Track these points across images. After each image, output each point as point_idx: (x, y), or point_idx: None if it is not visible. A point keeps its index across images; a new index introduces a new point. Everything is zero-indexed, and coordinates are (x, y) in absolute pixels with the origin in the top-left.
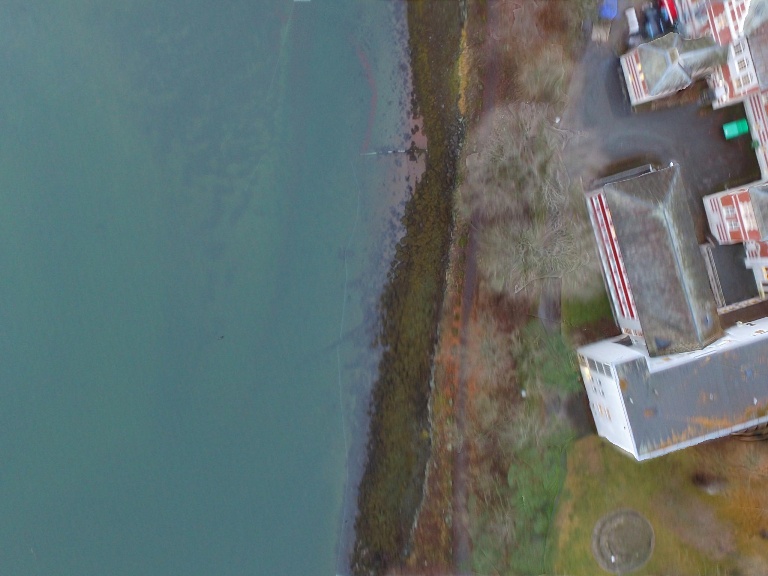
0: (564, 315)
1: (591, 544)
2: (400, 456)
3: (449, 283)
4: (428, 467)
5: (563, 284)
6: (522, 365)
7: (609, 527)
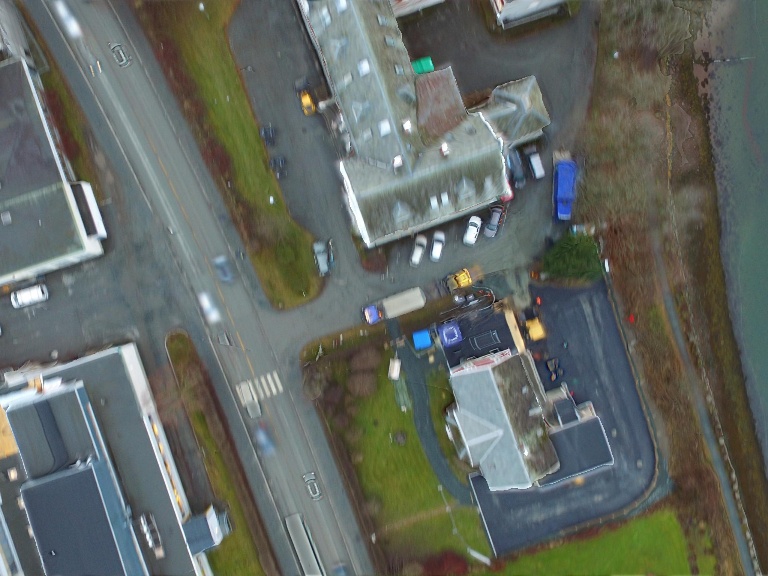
0: None
1: None
2: None
3: None
4: None
5: None
6: None
7: None
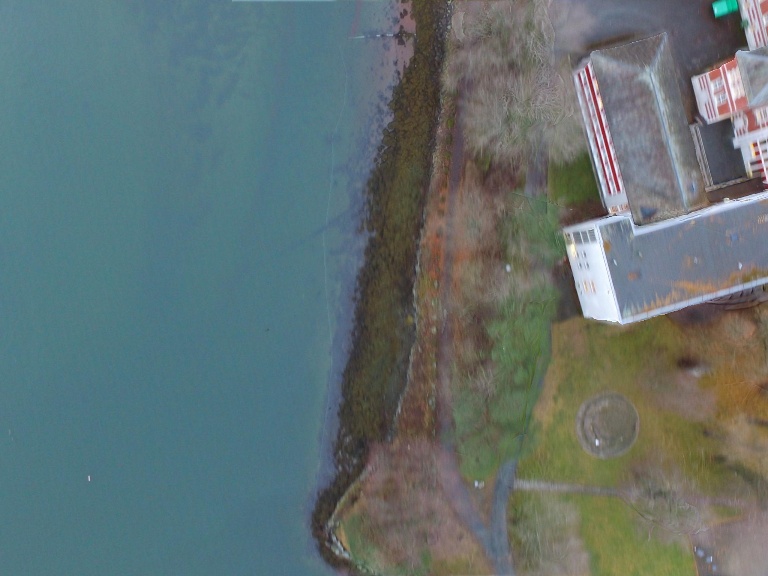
0: (550, 195)
1: (575, 427)
2: (385, 342)
3: (436, 166)
4: (412, 352)
5: (550, 163)
6: (507, 237)
7: (593, 410)
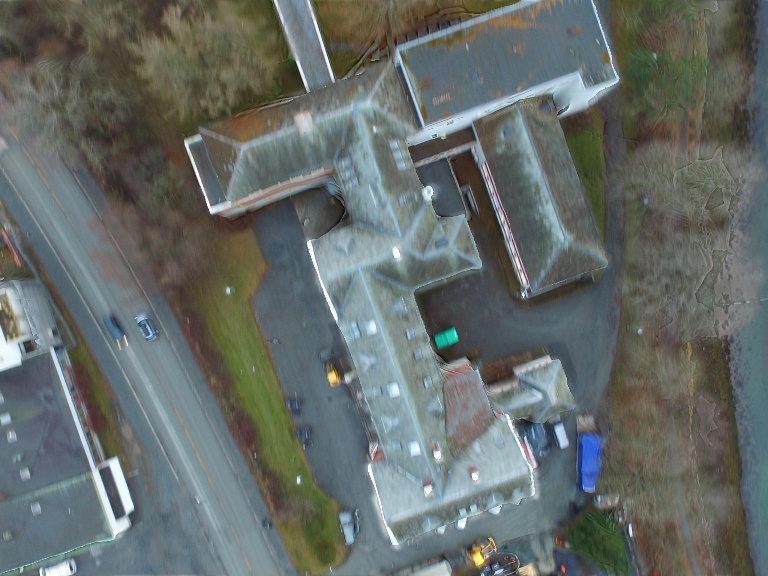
0: (600, 143)
1: None
2: None
3: None
4: None
5: (605, 174)
6: None
7: None
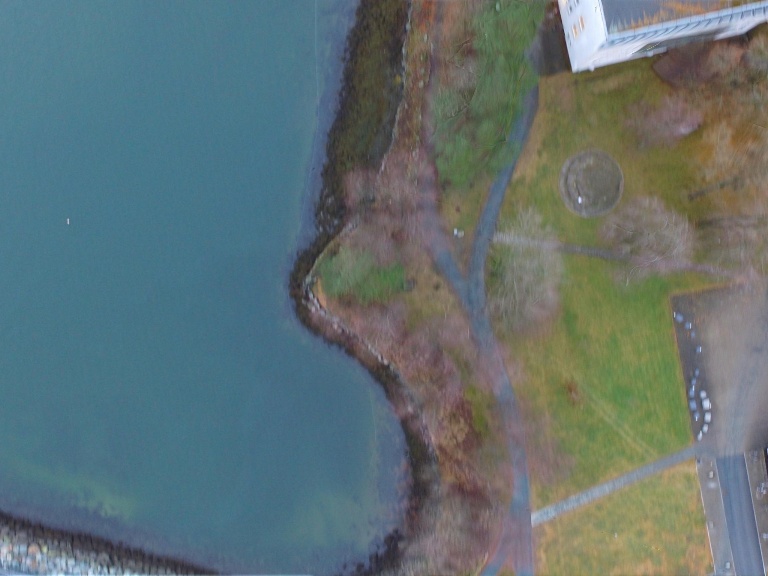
0: None
1: (558, 183)
2: (372, 102)
3: None
4: (399, 111)
5: None
6: None
7: (578, 166)
